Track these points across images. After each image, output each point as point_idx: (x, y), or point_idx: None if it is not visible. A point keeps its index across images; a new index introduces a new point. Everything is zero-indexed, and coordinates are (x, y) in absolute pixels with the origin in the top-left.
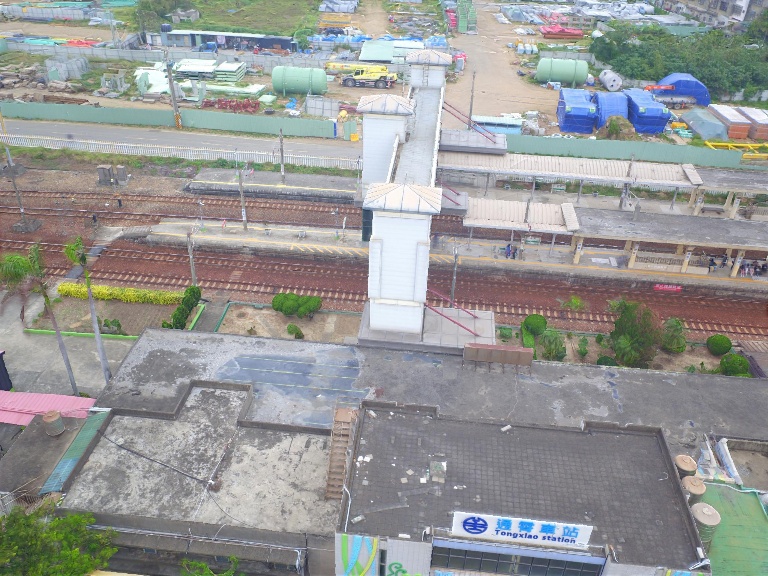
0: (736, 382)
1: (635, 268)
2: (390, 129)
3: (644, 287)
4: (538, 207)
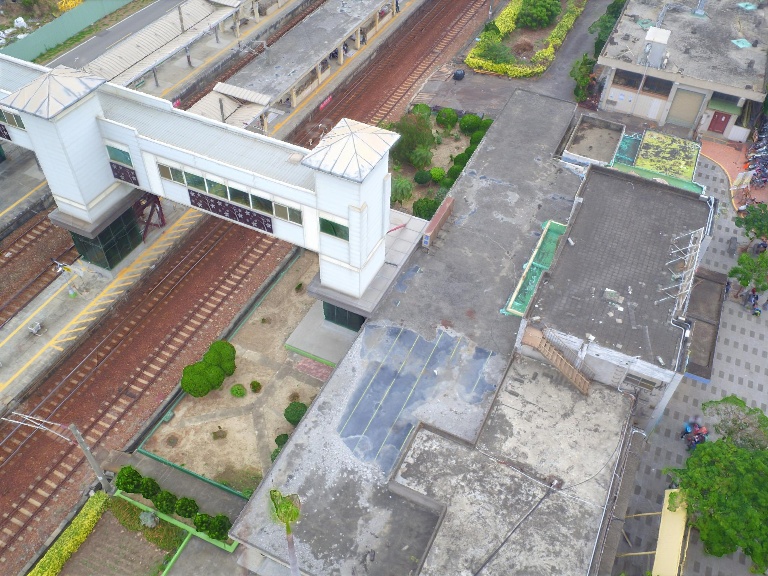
0: (502, 120)
1: (297, 104)
2: (86, 116)
3: (315, 114)
4: (205, 105)
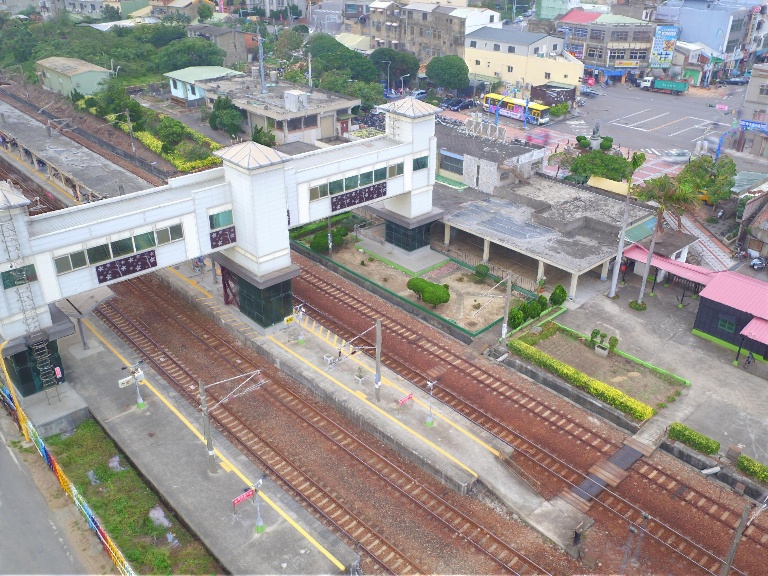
0: None
1: None
2: None
3: None
4: None
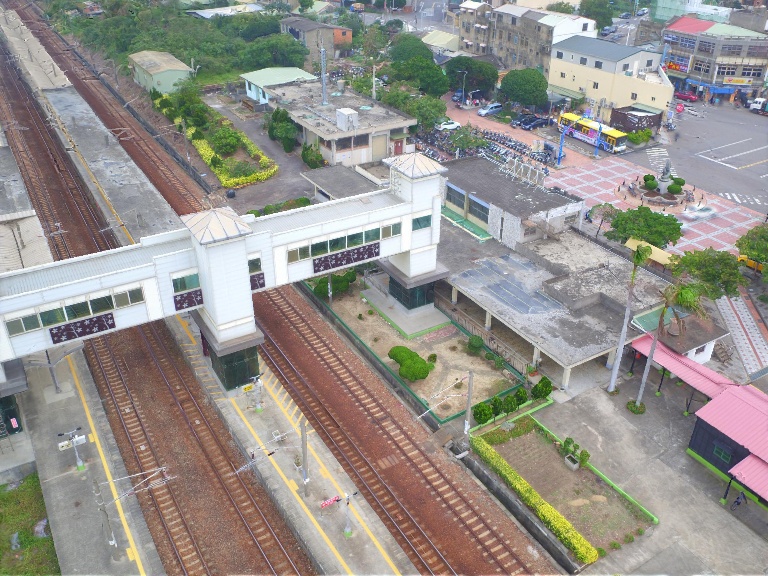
0: None
1: None
2: None
3: None
4: None
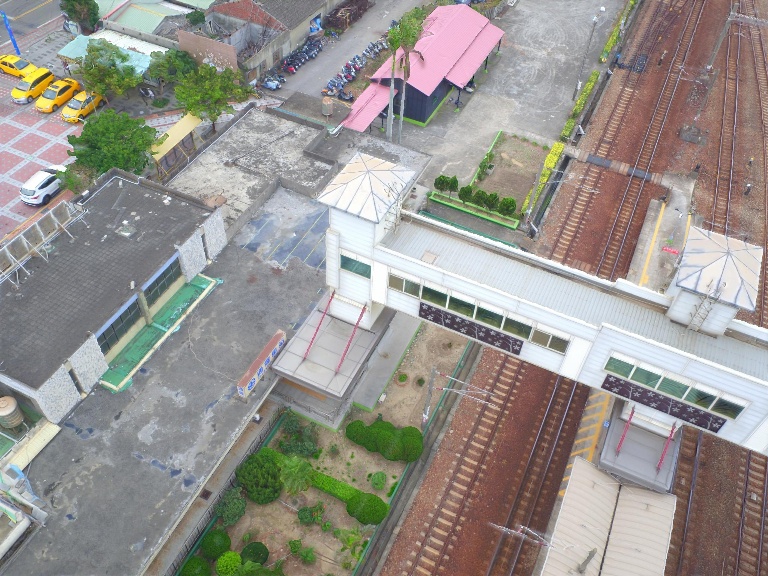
0: None
1: None
2: None
3: None
4: None
